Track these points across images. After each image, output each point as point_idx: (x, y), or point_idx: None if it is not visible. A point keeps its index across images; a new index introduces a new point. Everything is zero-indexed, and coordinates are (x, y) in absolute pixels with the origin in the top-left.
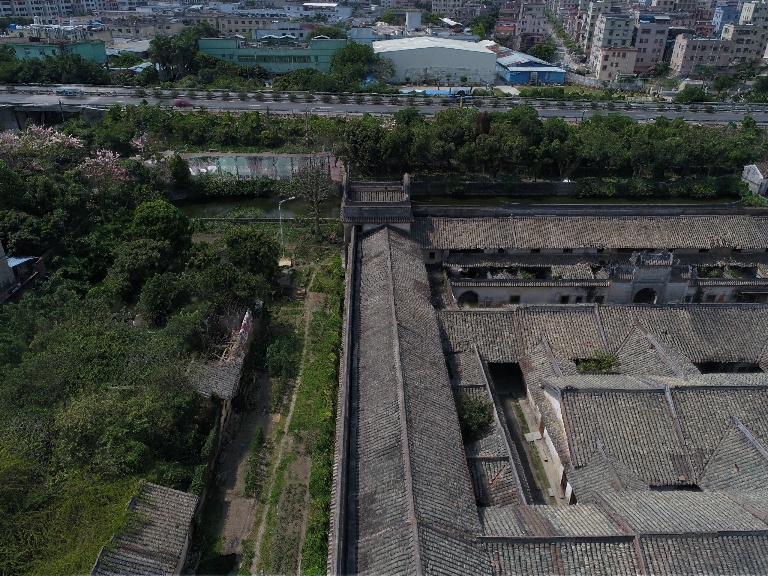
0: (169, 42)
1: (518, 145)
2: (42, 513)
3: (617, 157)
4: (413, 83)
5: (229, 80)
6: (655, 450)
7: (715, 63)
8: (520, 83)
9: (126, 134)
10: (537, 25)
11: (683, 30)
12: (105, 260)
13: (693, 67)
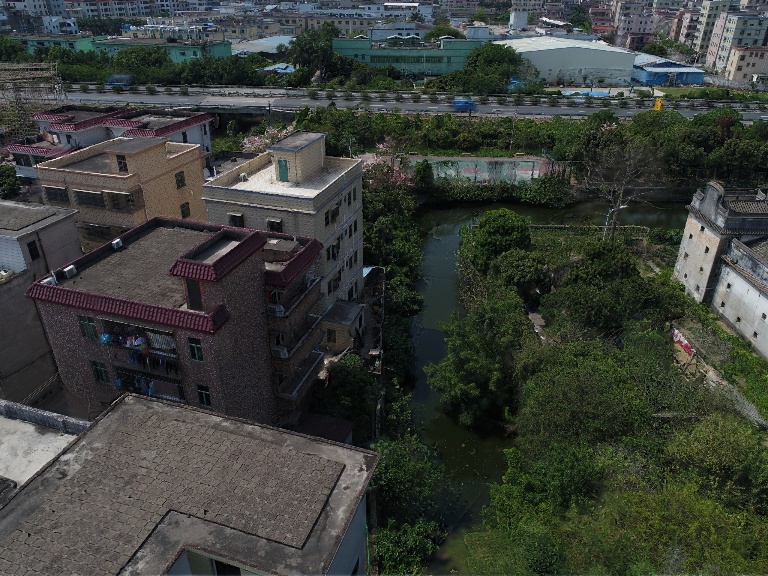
0: (310, 43)
1: None
2: (759, 561)
3: None
4: (549, 84)
5: (388, 81)
6: None
7: None
8: (656, 84)
9: (334, 137)
10: (644, 24)
11: None
12: (419, 269)
13: None
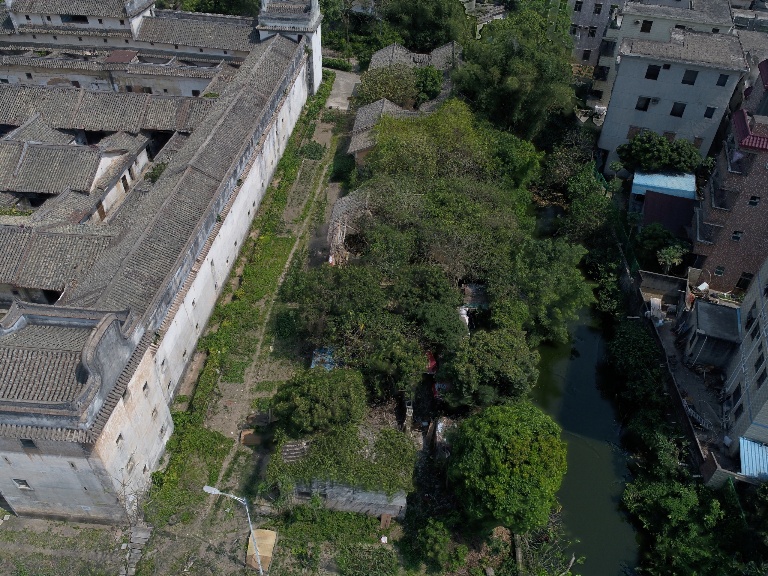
0: None
1: None
2: None
3: None
4: None
5: None
6: None
7: None
8: None
9: None
10: None
11: None
12: None
13: None
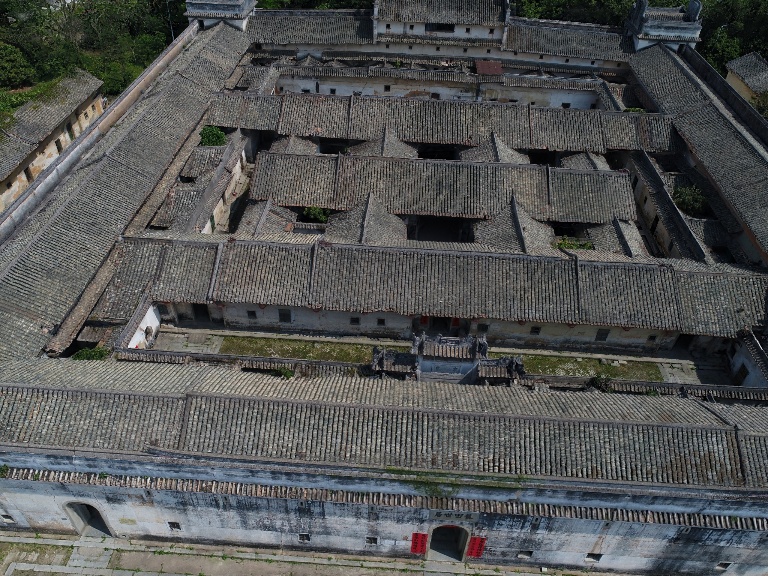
0: None
1: None
2: None
3: None
4: None
5: None
6: None
7: None
8: None
9: None
10: None
11: None
12: None
13: None
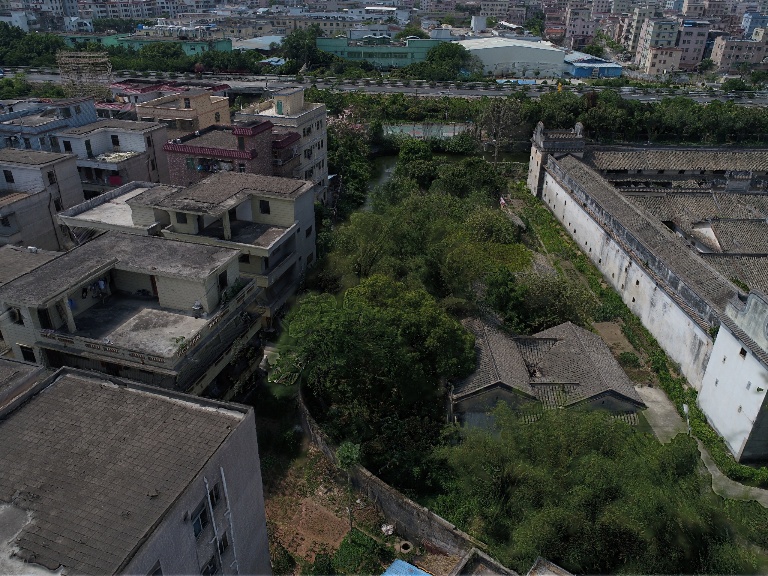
0: (298, 40)
1: (620, 115)
2: None
3: (689, 127)
4: (495, 76)
5: (360, 71)
6: (763, 245)
7: (749, 61)
8: (583, 77)
9: None
10: (586, 28)
11: (719, 33)
12: (366, 182)
13: (730, 64)
